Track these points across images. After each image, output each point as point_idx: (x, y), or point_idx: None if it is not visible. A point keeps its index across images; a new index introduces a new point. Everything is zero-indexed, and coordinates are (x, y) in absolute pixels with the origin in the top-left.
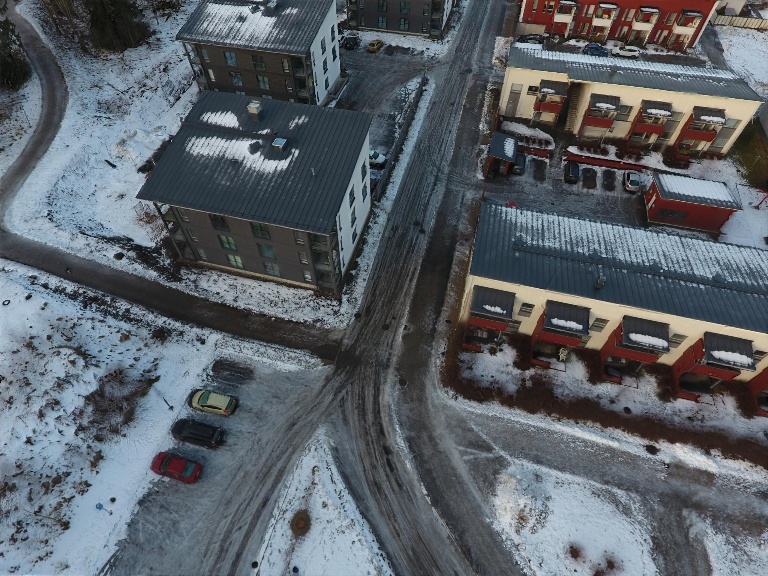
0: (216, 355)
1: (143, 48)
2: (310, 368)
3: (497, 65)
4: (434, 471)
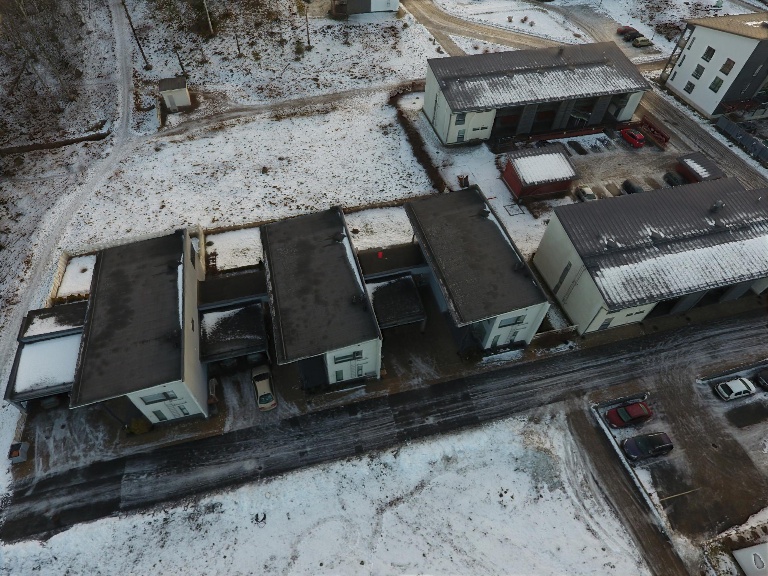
0: (664, 53)
1: None
2: None
3: None
4: None
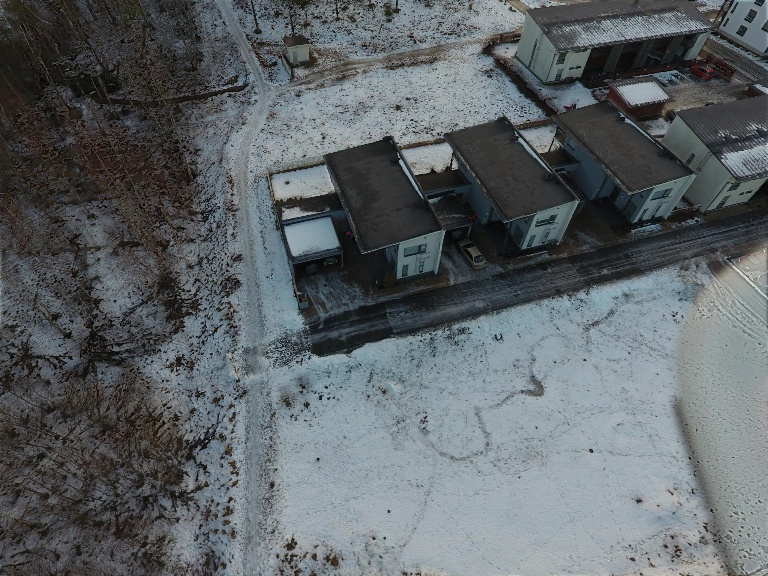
0: None
1: None
2: None
3: None
4: None
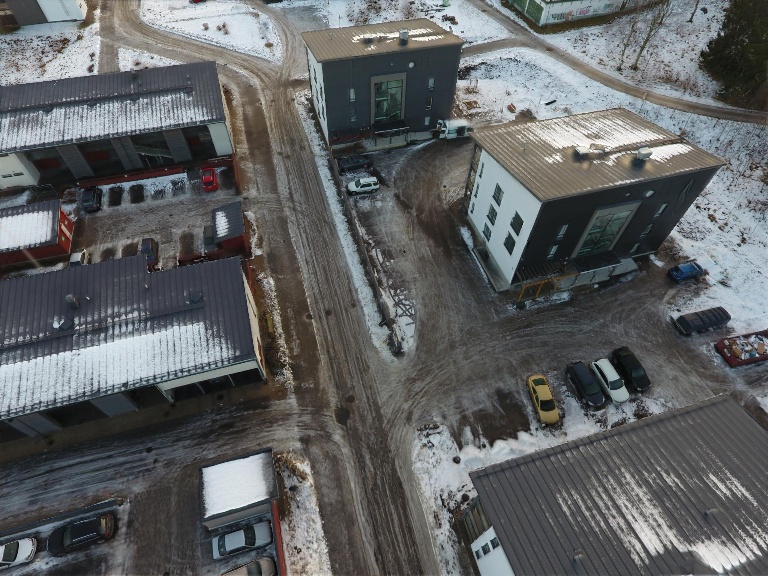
0: None
1: (761, 197)
2: (301, 75)
3: (297, 458)
4: (222, 69)
